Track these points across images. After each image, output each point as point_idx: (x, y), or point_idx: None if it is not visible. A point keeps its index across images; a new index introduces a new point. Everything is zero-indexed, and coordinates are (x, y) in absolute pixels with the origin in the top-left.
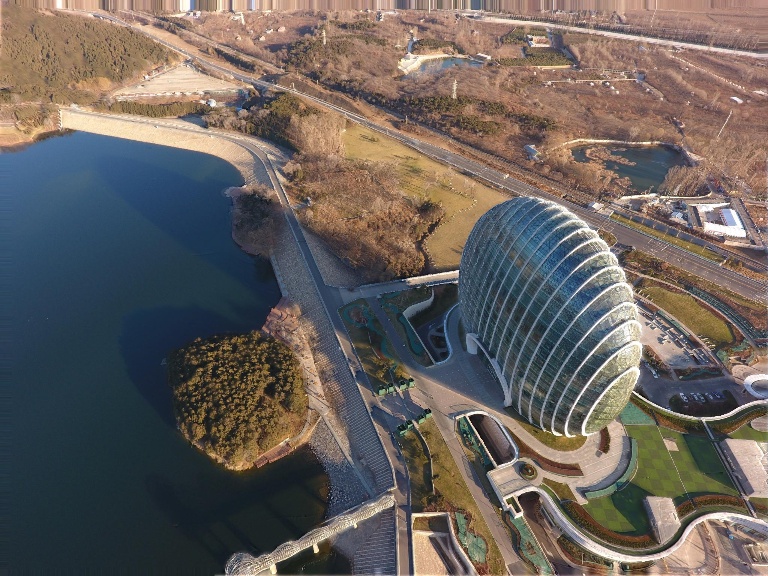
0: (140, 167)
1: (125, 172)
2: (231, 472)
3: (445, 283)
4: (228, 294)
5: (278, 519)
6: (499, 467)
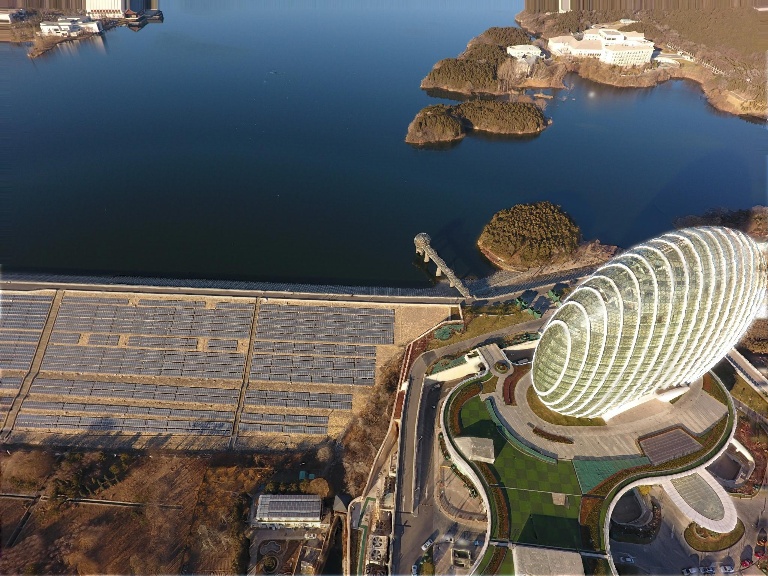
0: (758, 166)
1: (741, 160)
2: (477, 242)
3: (729, 361)
4: (620, 225)
5: (452, 261)
6: (501, 350)
